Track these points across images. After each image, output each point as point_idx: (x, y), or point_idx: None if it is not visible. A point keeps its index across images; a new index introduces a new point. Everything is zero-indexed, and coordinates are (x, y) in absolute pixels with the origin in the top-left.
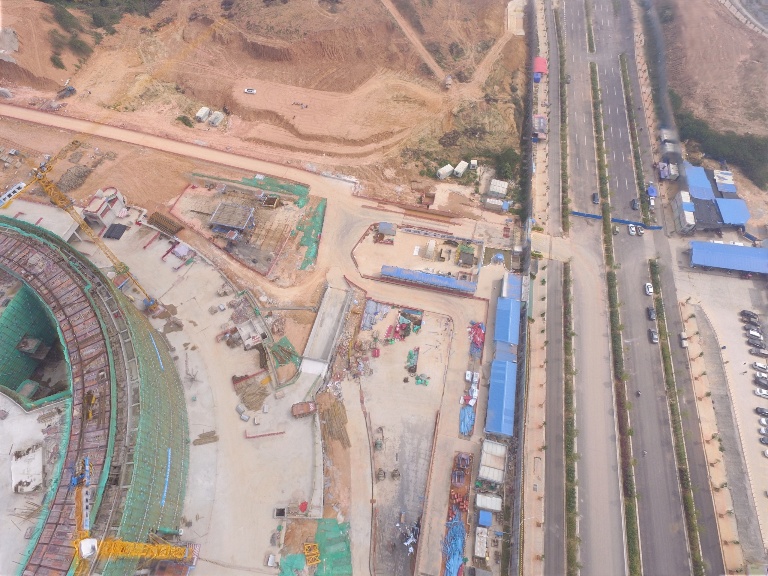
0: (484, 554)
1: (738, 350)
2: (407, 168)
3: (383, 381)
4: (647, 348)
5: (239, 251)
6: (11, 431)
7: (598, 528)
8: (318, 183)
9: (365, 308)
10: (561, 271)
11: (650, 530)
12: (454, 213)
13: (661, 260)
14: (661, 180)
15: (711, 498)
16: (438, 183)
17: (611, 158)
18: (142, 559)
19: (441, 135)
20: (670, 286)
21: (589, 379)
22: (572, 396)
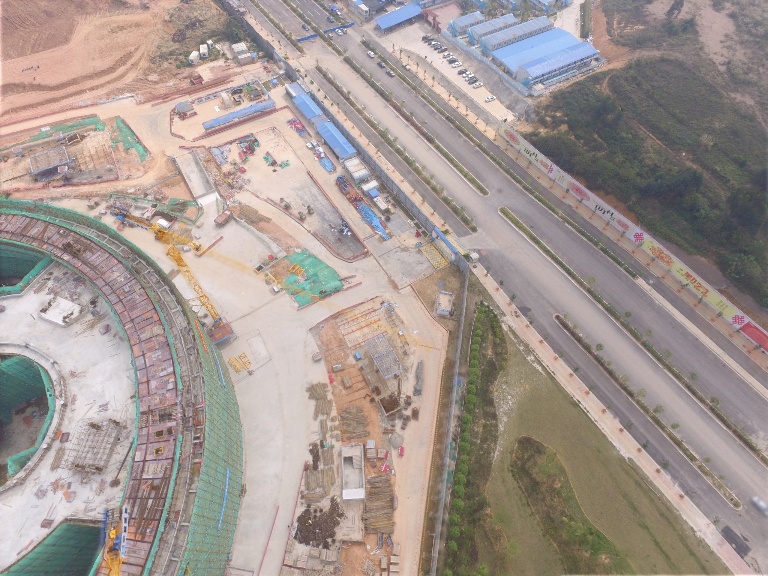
0: (386, 206)
1: (433, 55)
2: (164, 67)
3: (261, 180)
4: (392, 80)
5: (79, 179)
6: (19, 311)
7: (430, 163)
8: (101, 110)
9: (212, 154)
10: (317, 72)
11: (452, 148)
12: (223, 76)
13: (366, 37)
14: (334, 1)
15: (467, 120)
16: (195, 68)
17: (296, 3)
18: (194, 312)
19: (171, 37)
20: (380, 48)
21: (375, 110)
22: (372, 121)
